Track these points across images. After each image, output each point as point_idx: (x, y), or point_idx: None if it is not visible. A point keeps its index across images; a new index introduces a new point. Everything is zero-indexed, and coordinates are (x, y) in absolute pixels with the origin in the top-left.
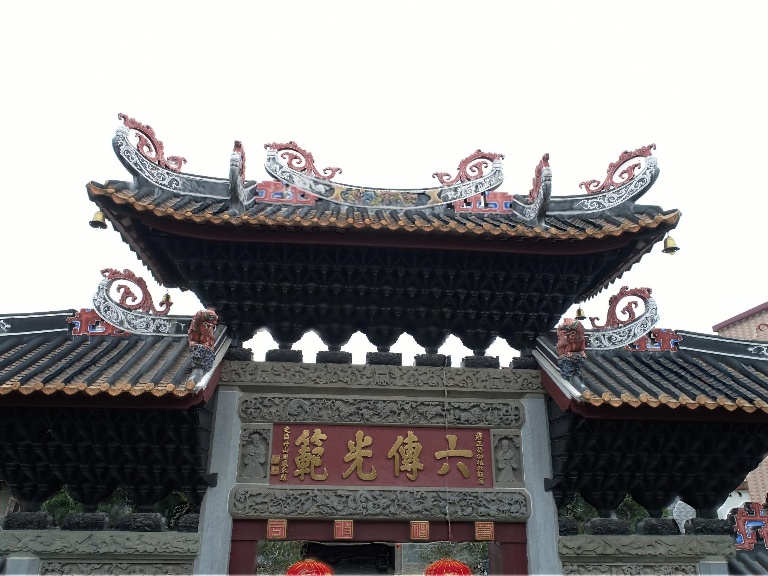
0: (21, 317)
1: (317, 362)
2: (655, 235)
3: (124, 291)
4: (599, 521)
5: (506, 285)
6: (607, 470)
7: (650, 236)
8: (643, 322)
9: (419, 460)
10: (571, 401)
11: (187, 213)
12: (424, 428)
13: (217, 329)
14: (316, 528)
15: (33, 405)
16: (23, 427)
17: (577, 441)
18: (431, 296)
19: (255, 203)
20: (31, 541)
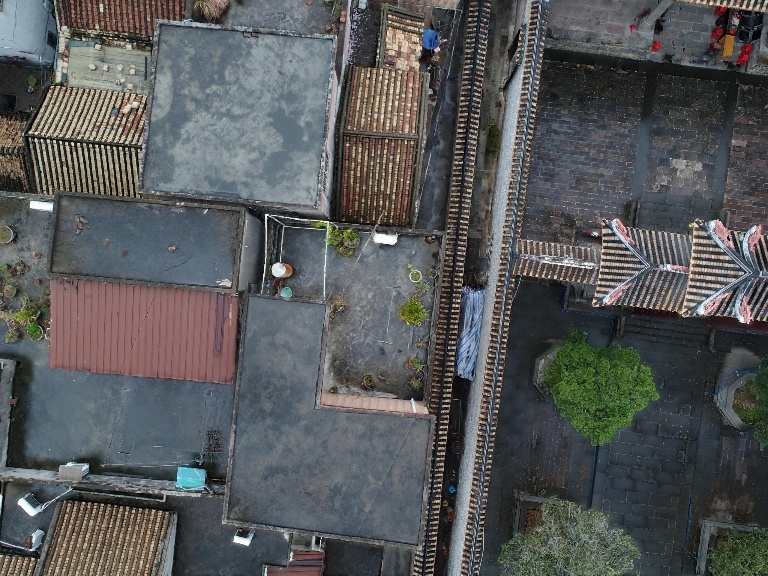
0: None
1: None
2: None
3: None
4: None
5: None
6: None
7: None
8: None
9: None
10: None
11: None
12: None
13: None
14: None
15: None
16: None
17: None
18: None
19: None
20: None
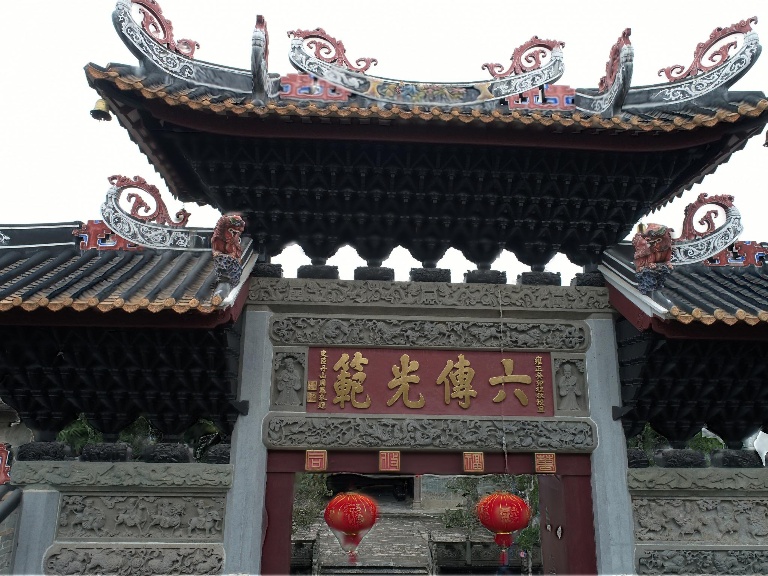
0: (21, 228)
1: (355, 279)
2: (754, 127)
3: (135, 200)
4: (672, 452)
5: (572, 189)
6: (685, 397)
7: (748, 128)
8: (724, 233)
9: (472, 386)
10: (652, 319)
11: (204, 102)
12: (477, 352)
13: (242, 242)
14: (359, 459)
15: (39, 324)
16: (30, 349)
17: (654, 365)
18: (485, 203)
19: (279, 99)
20: (48, 473)
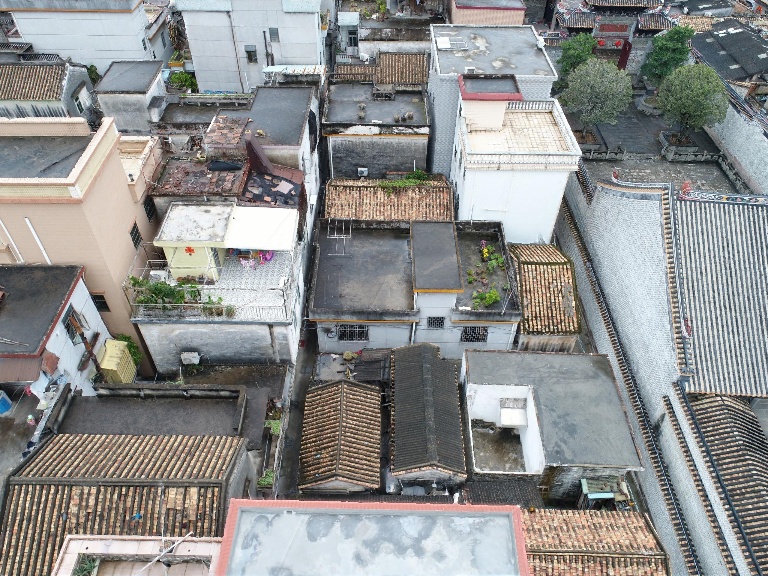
0: None
1: None
2: None
3: (655, 7)
4: None
5: None
6: None
7: None
8: None
9: None
10: None
11: None
12: None
13: None
14: None
15: None
16: None
17: None
18: None
19: None
20: None
